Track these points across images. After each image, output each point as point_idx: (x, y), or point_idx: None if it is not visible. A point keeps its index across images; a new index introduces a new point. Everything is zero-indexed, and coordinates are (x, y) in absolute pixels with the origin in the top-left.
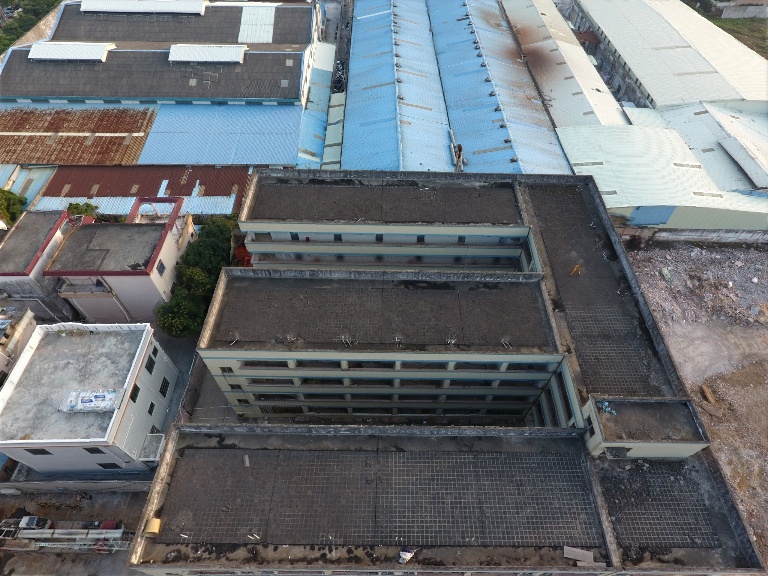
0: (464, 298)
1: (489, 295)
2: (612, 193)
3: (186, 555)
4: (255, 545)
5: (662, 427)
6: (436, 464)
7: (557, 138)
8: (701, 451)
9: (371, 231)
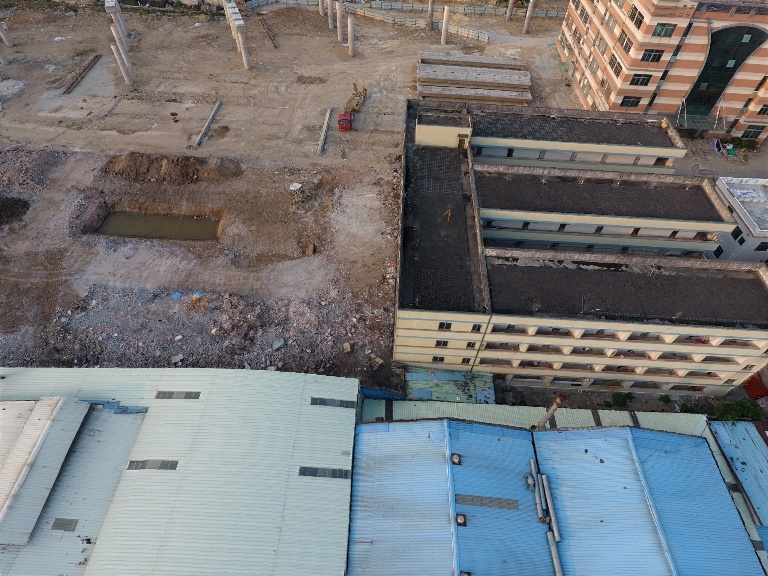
0: (539, 205)
1: (520, 206)
2: (318, 401)
3: (644, 123)
4: (618, 123)
5: (437, 120)
6: (545, 137)
7: (349, 569)
8: (407, 133)
9: (634, 263)
